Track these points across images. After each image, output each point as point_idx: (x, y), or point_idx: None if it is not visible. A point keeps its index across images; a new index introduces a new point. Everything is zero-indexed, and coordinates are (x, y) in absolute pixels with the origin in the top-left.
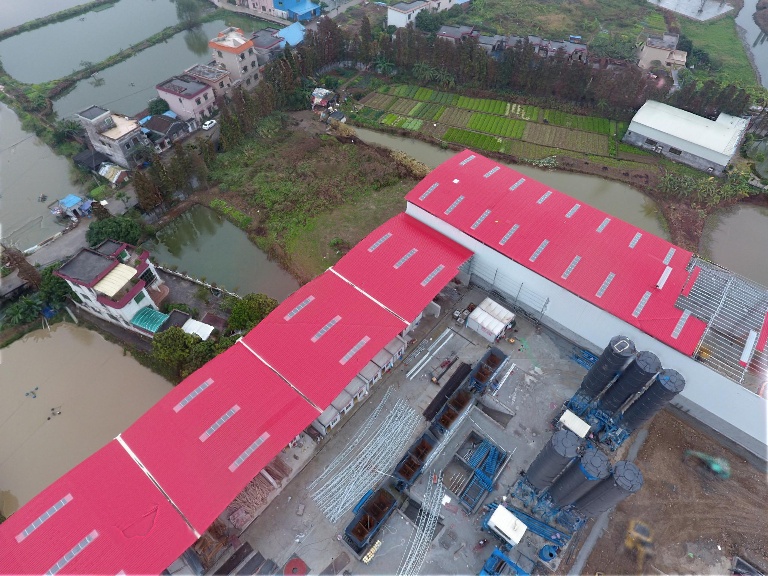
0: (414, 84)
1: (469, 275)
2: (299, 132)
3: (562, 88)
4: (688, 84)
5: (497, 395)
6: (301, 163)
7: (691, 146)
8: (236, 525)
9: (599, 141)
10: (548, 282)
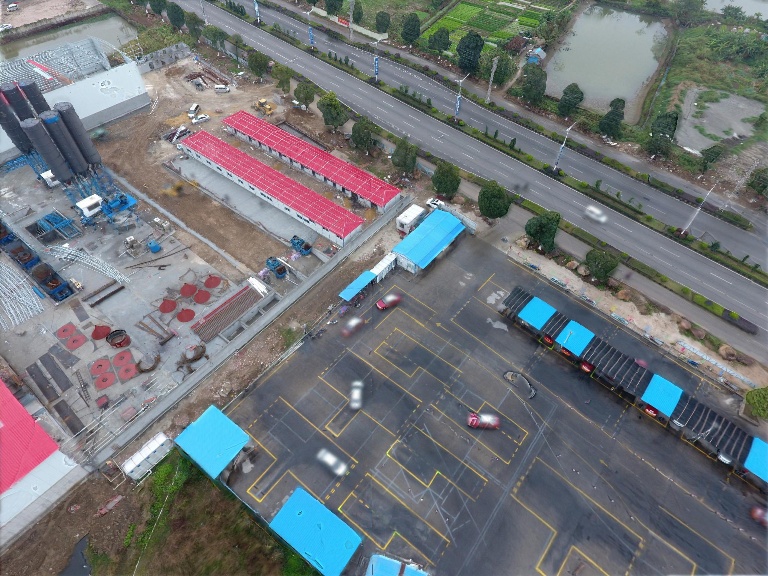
0: None
1: None
2: None
3: None
4: None
5: (7, 214)
6: None
7: None
8: (6, 378)
9: None
10: None
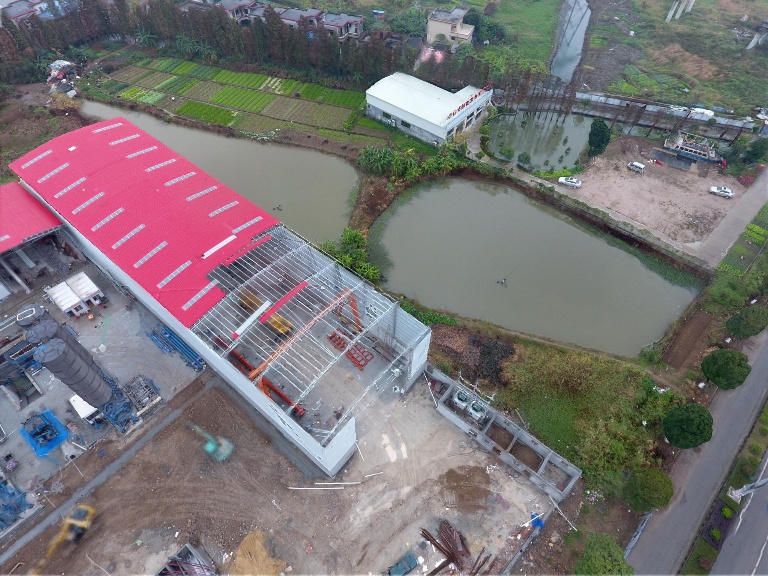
0: (180, 58)
1: (77, 249)
2: (16, 105)
3: (316, 60)
4: (428, 55)
5: (37, 374)
6: None
7: (415, 118)
8: None
9: (341, 115)
10: None
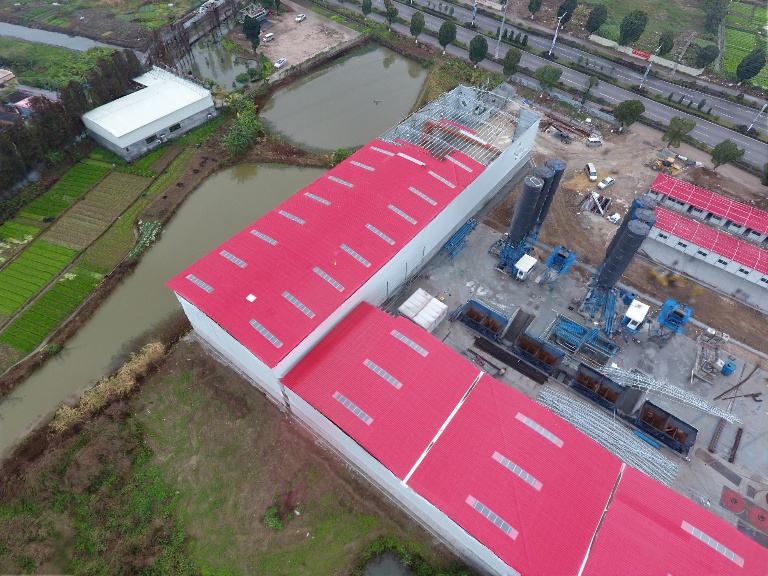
0: None
1: None
2: None
3: None
4: (90, 76)
5: None
6: None
7: (180, 113)
8: None
9: (121, 180)
10: (416, 238)
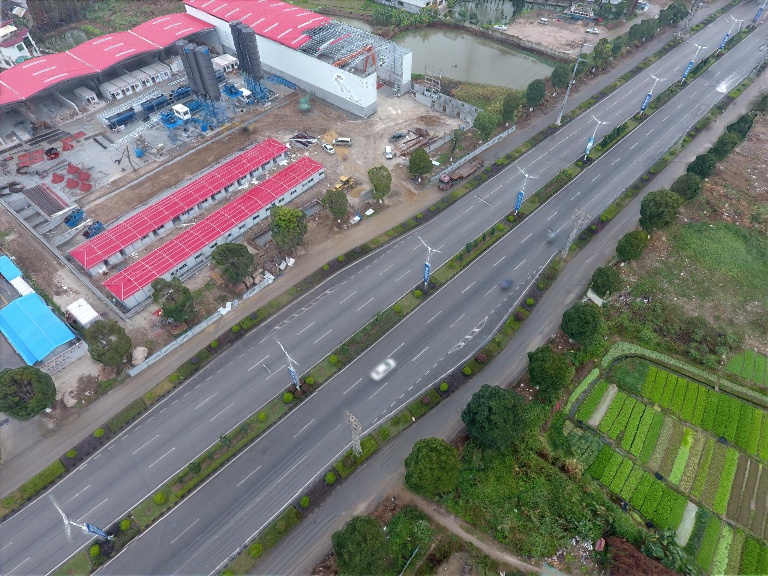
0: None
1: (221, 46)
2: None
3: None
4: None
5: None
6: (144, 6)
7: None
8: (55, 123)
9: (359, 2)
10: None
